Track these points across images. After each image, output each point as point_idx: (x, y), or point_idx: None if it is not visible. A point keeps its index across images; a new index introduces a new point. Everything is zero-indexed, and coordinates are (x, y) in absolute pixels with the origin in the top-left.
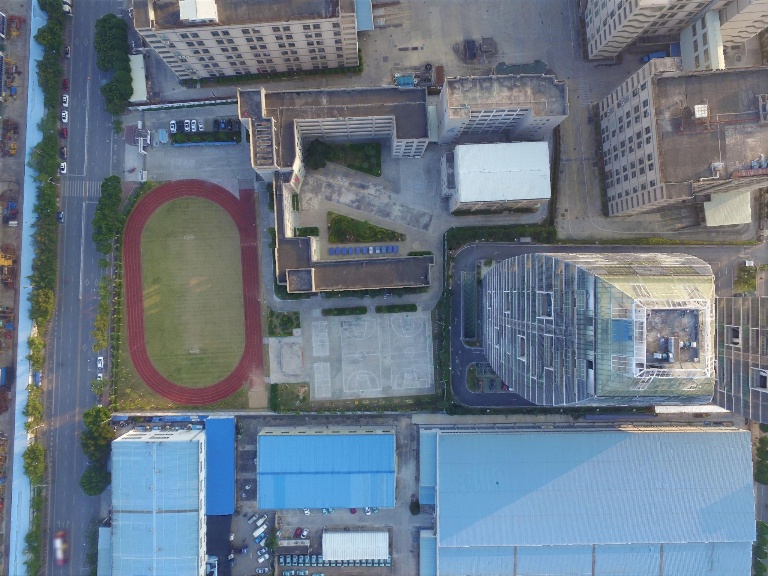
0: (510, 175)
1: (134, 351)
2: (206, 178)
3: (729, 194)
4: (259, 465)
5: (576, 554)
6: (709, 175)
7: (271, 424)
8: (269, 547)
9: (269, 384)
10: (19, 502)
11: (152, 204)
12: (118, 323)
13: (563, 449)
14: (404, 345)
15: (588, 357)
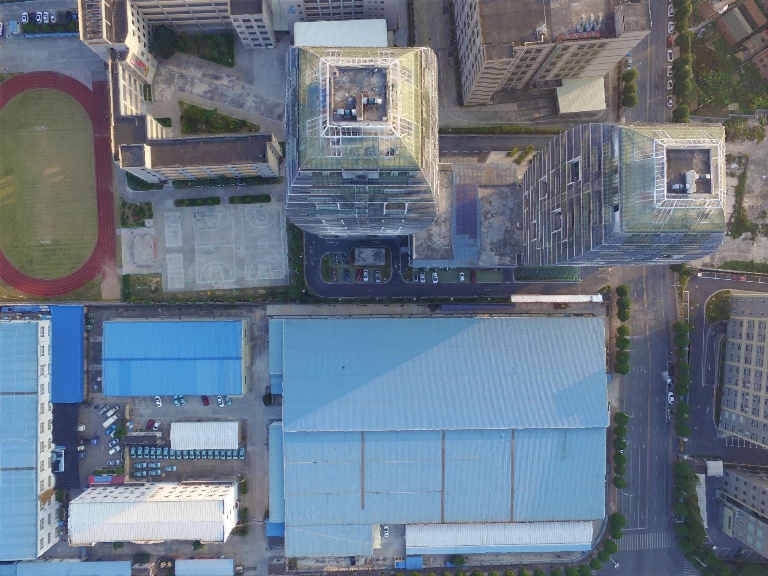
0: None
1: None
2: (59, 70)
3: (582, 80)
4: (104, 351)
5: (425, 440)
6: (534, 39)
7: (123, 315)
8: (117, 436)
9: (122, 275)
10: None
11: (5, 96)
12: None
13: (411, 334)
14: (258, 236)
15: None
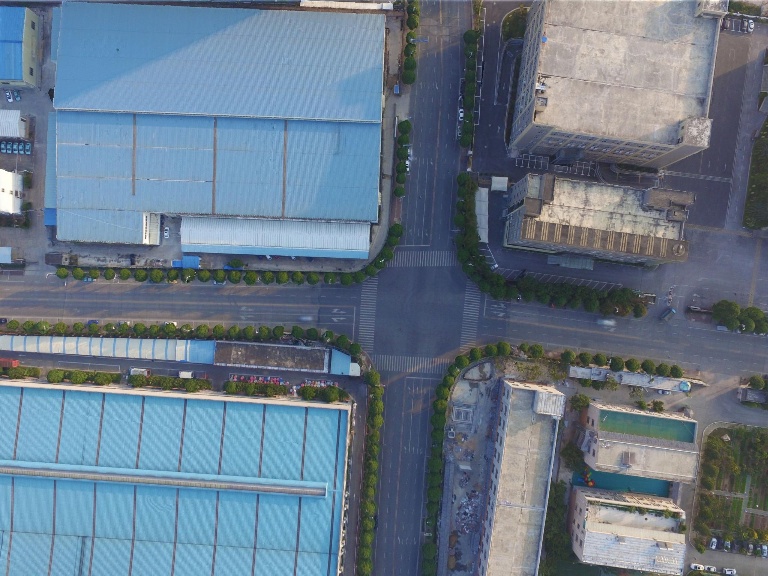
0: None
1: None
2: None
3: None
4: None
5: (197, 128)
6: None
7: None
8: None
9: None
10: None
11: None
12: None
13: (188, 21)
14: None
15: None
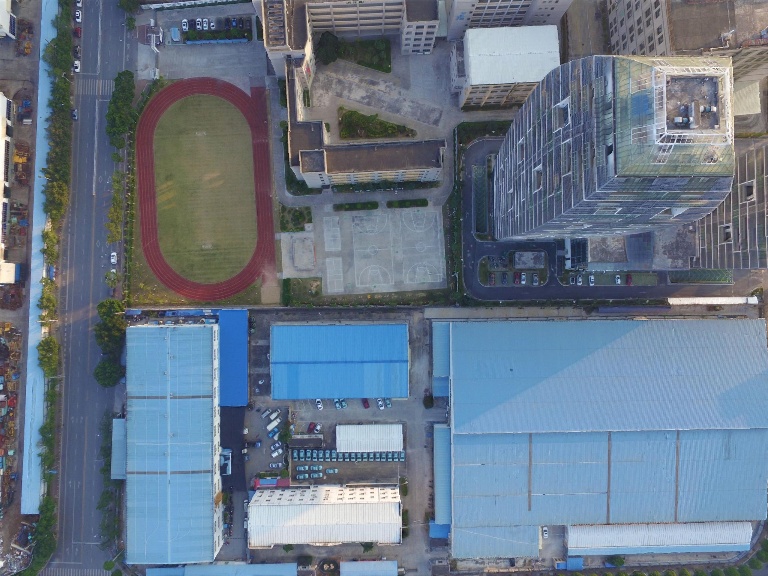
0: (520, 58)
1: (147, 247)
2: (218, 76)
3: (738, 84)
4: (272, 355)
5: (592, 442)
6: (719, 45)
7: (284, 319)
8: (283, 439)
9: (281, 279)
10: (34, 390)
11: (164, 102)
12: (131, 218)
13: (577, 336)
14: (416, 240)
15: (607, 142)
